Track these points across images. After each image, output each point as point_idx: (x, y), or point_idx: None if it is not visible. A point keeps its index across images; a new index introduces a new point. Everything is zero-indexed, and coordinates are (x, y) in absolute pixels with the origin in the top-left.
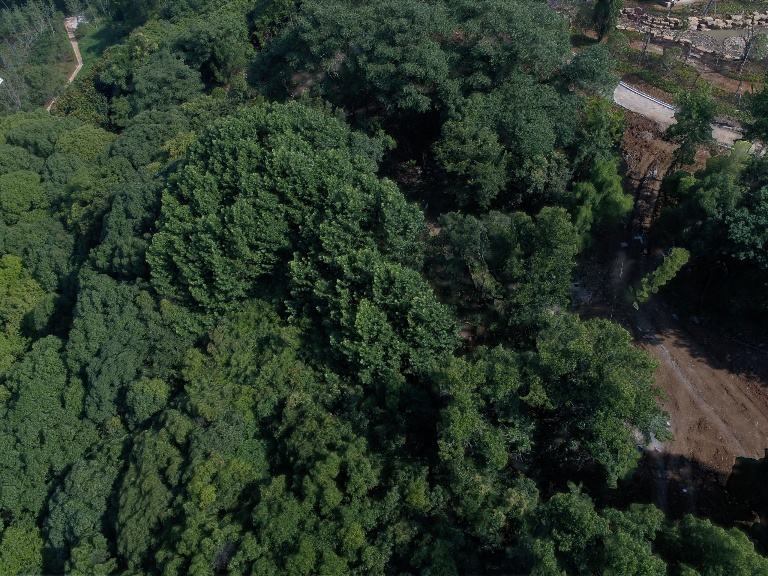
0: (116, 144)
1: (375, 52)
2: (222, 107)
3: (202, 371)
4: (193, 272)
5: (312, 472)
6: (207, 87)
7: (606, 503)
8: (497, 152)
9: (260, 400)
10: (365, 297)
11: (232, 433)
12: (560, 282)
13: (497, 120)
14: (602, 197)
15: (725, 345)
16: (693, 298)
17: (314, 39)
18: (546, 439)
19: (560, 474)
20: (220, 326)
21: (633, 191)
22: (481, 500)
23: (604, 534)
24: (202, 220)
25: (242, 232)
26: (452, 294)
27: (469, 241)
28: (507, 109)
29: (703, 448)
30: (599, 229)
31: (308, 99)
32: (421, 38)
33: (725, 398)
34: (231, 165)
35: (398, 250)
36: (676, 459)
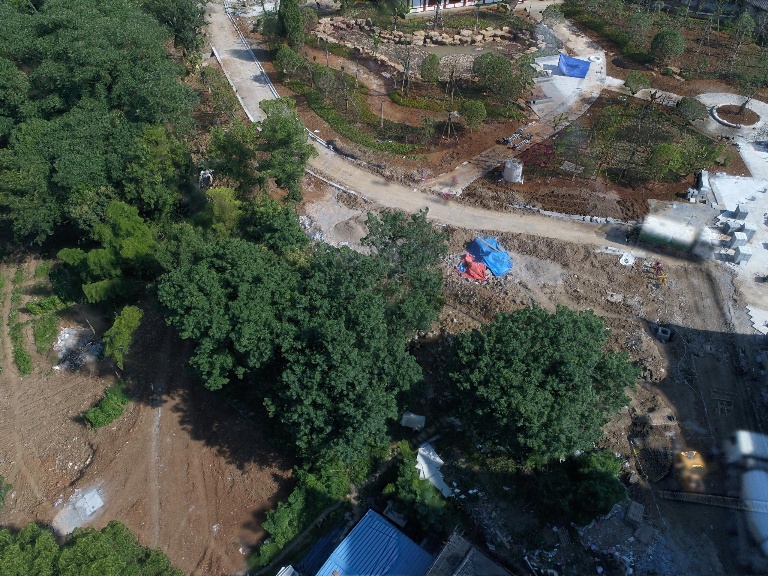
0: None
1: None
2: None
3: None
4: None
5: None
6: None
7: None
8: (27, 185)
9: None
10: None
11: None
12: None
13: None
14: None
15: (219, 412)
16: None
17: None
18: None
19: None
20: None
21: None
22: None
23: None
24: None
25: None
26: None
27: None
28: None
29: None
30: None
31: None
32: None
33: (180, 475)
34: None
35: None
36: None
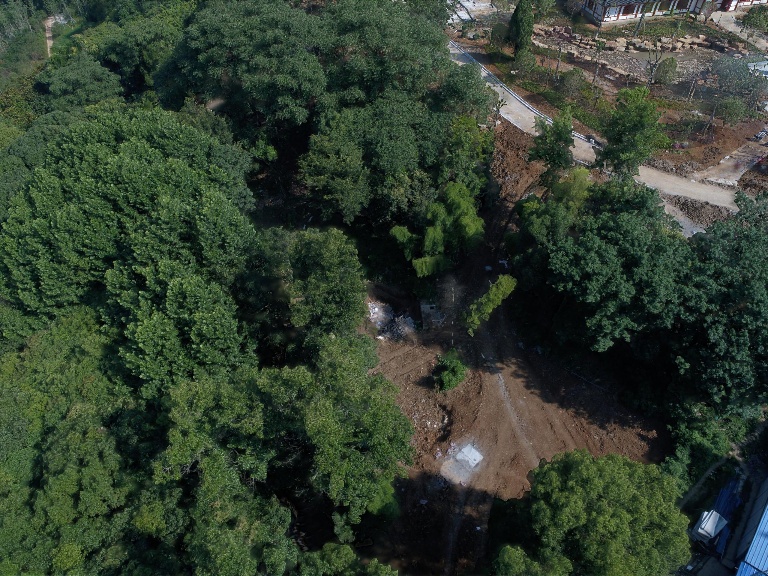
0: (13, 143)
1: (249, 62)
2: (125, 111)
3: (12, 376)
4: (24, 275)
5: (46, 487)
6: (141, 90)
7: (398, 536)
8: (354, 168)
9: (51, 409)
10: (160, 310)
11: (5, 441)
12: (350, 305)
13: (365, 135)
14: (454, 219)
15: (562, 378)
16: (542, 327)
17: (202, 47)
18: (308, 467)
19: (328, 504)
20: (40, 331)
21: (507, 214)
22: (214, 527)
23: (241, 575)
24: (31, 224)
25: (69, 238)
26: (260, 311)
27: (280, 258)
28: (375, 125)
29: (509, 485)
30: (467, 251)
31: (192, 107)
32: (296, 50)
33: (547, 433)
34: (76, 170)
35: (217, 264)
36: (479, 495)
